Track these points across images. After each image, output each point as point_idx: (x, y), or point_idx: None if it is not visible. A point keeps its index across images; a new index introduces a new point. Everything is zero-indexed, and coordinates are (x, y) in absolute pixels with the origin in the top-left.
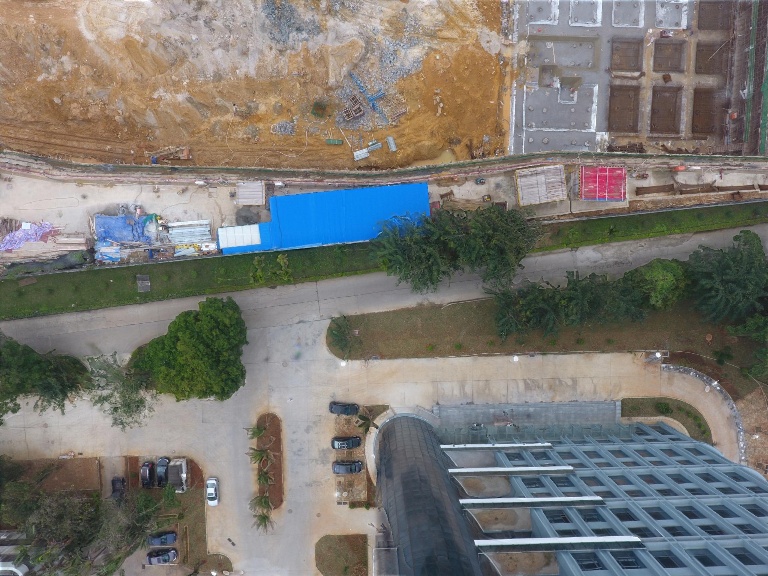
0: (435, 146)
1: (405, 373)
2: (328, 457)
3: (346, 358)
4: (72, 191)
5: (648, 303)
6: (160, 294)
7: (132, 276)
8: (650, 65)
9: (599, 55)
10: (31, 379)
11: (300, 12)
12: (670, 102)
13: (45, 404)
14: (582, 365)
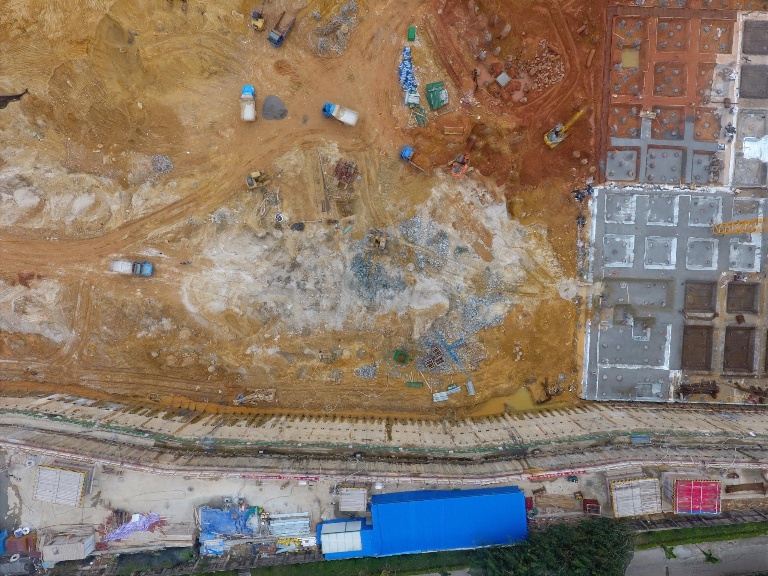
0: (512, 387)
1: None
2: None
3: None
4: (179, 484)
5: None
6: None
7: (234, 569)
8: (723, 306)
9: (673, 296)
10: None
11: (387, 269)
12: (743, 339)
13: None
14: None
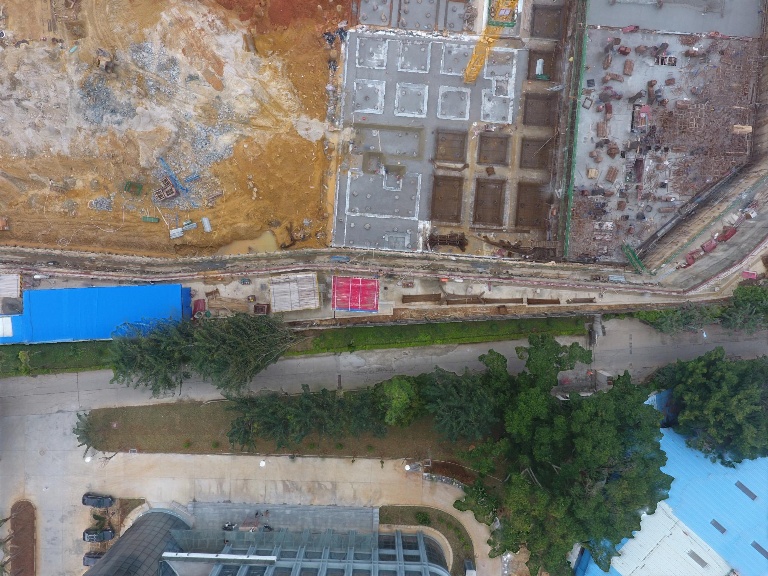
0: (252, 228)
1: (163, 468)
2: (82, 547)
3: None
4: None
5: (383, 420)
6: None
7: None
8: (474, 157)
9: (423, 145)
10: None
11: (116, 95)
12: (495, 194)
13: None
14: (342, 469)
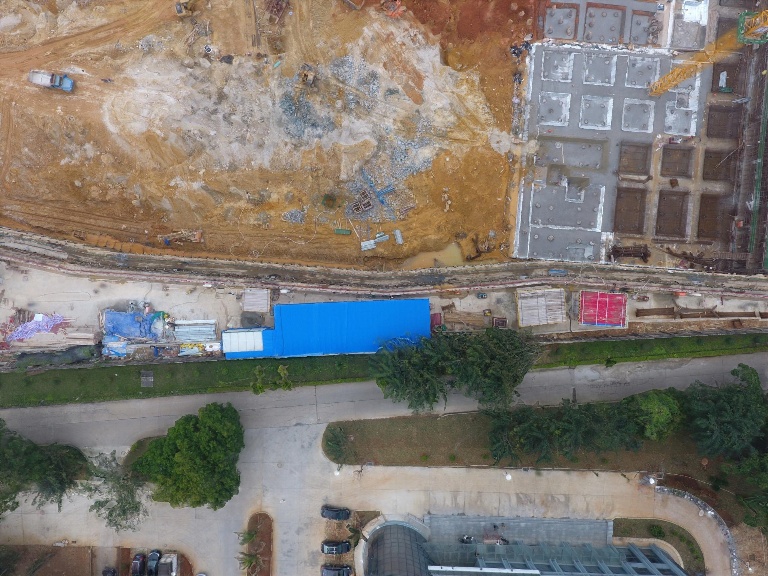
0: (441, 240)
1: (398, 480)
2: (317, 560)
3: (340, 464)
4: (85, 286)
5: (643, 434)
6: (162, 390)
7: (136, 372)
8: (658, 169)
9: (607, 157)
10: (31, 479)
11: (316, 109)
12: (676, 205)
13: (43, 500)
14: (575, 482)
